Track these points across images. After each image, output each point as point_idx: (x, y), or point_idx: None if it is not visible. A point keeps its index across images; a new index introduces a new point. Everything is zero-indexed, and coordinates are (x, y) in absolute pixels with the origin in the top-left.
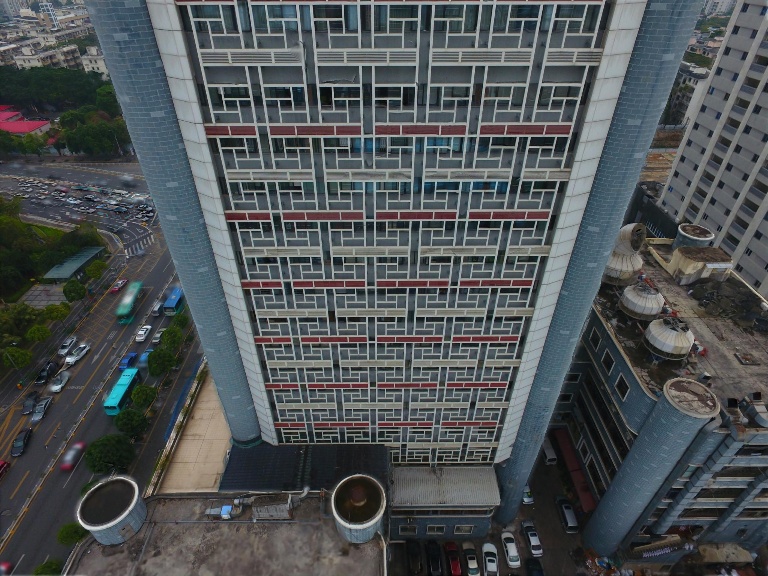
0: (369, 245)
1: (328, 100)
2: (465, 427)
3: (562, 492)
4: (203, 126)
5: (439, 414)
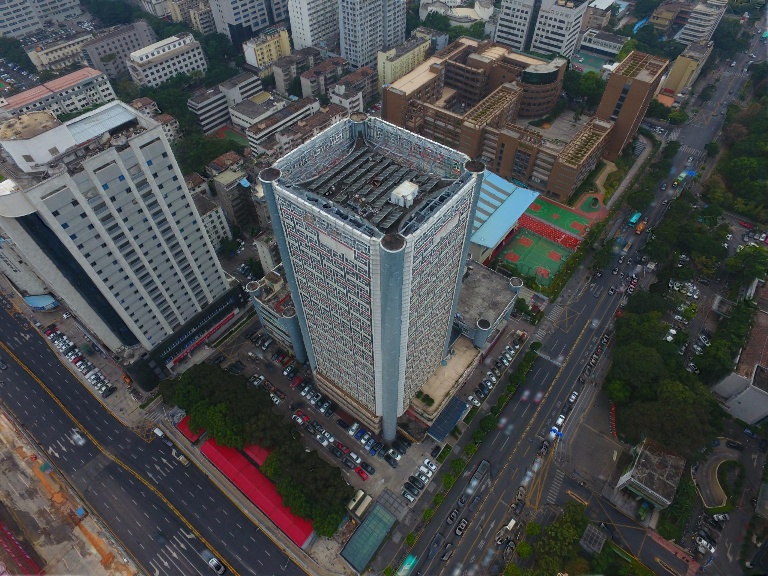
0: None
1: None
2: None
3: None
4: None
5: None
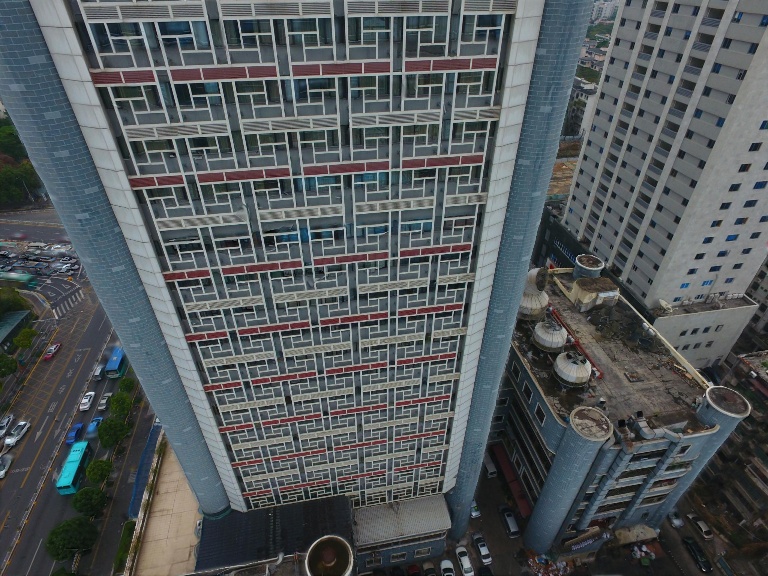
0: (316, 344)
1: (271, 241)
2: (414, 469)
3: (504, 501)
4: (162, 274)
5: (391, 463)
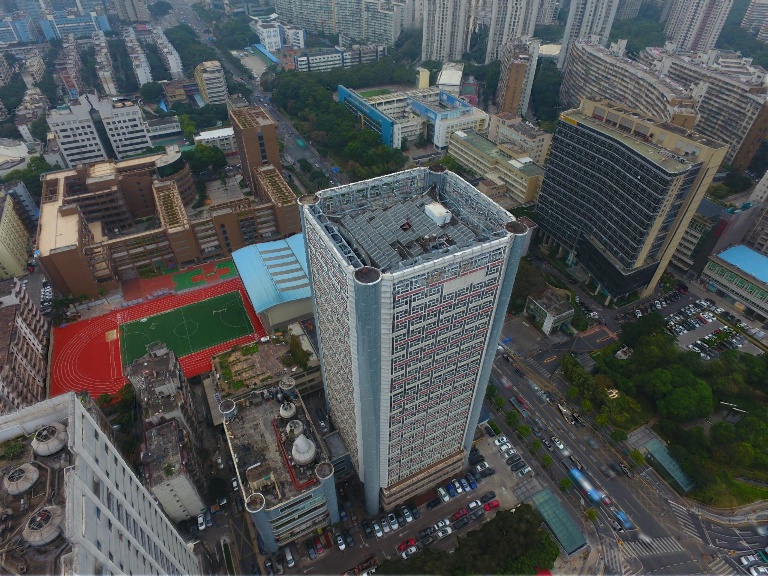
0: None
1: None
2: None
3: None
4: None
5: None
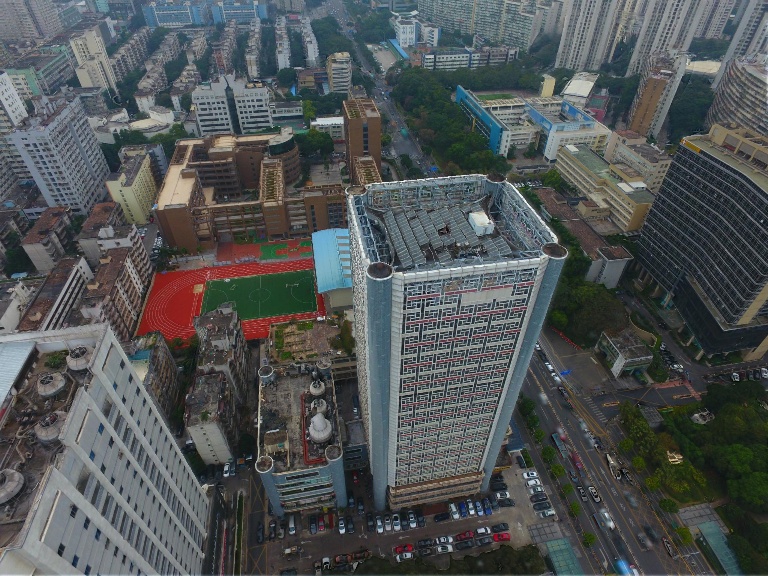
0: None
1: None
2: None
3: None
4: None
5: None
